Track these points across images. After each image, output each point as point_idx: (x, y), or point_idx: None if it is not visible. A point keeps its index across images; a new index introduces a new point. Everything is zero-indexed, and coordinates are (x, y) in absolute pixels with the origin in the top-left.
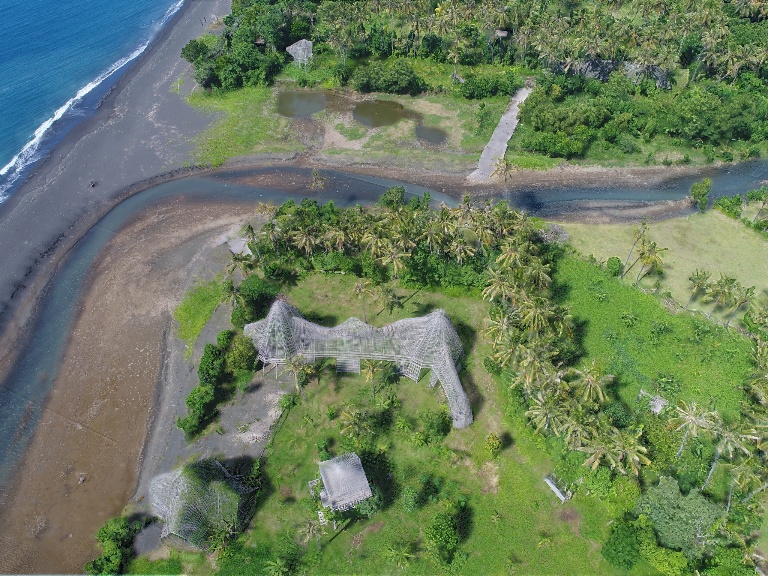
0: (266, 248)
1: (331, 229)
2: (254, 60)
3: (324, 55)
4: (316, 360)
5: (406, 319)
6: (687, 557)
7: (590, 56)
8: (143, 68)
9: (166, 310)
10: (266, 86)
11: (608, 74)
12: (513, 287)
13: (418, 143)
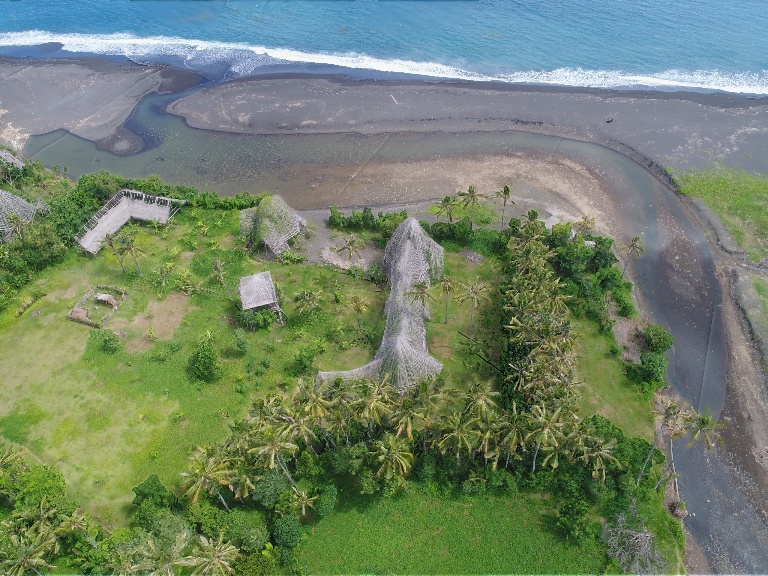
0: None
1: None
2: None
3: None
4: None
5: (406, 320)
6: None
7: None
8: None
9: None
10: None
11: None
12: None
13: None
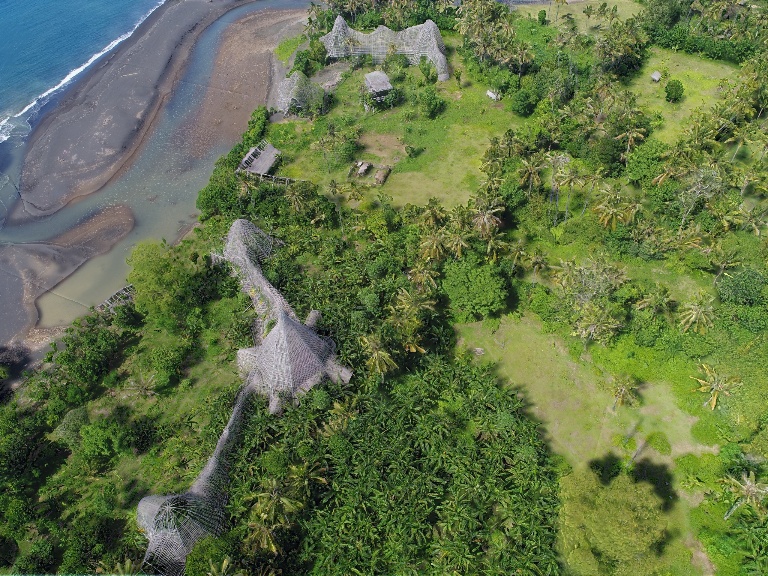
0: (327, 16)
1: None
2: None
3: None
4: (360, 61)
5: (412, 26)
6: None
7: None
8: None
9: (268, 51)
10: None
11: None
12: (472, 1)
13: None
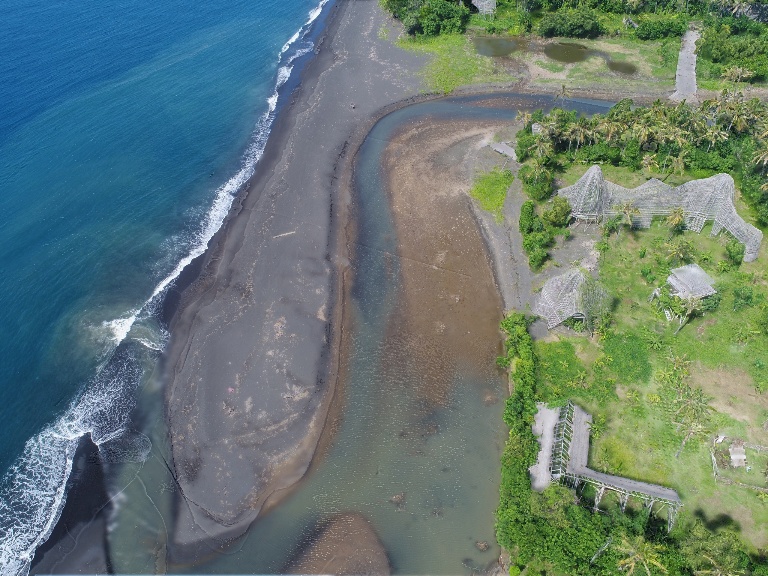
0: None
1: (601, 123)
2: (449, 11)
3: (499, 9)
4: None
5: (695, 180)
6: None
7: (749, 1)
8: (342, 22)
9: (462, 192)
10: (460, 33)
11: (767, 16)
12: None
13: (614, 74)
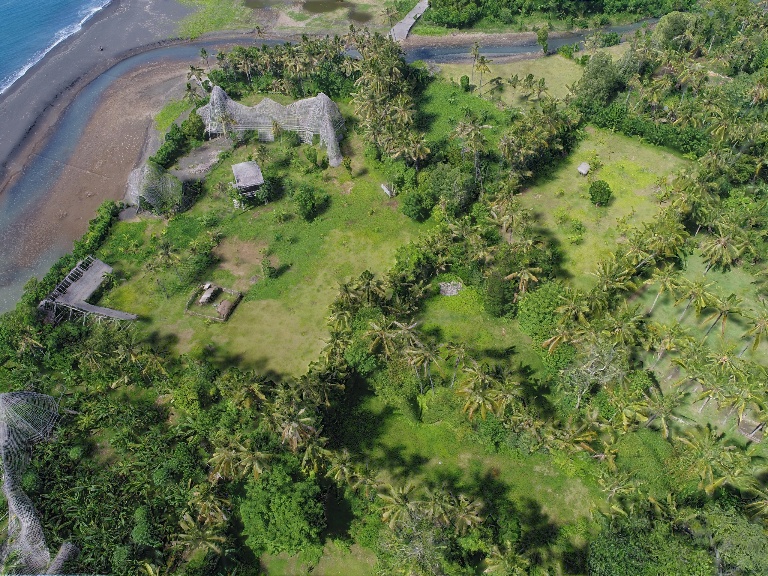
0: (220, 76)
1: None
2: None
3: None
4: (246, 136)
5: None
6: (448, 204)
7: None
8: None
9: (149, 116)
10: None
11: None
12: (370, 72)
13: (348, 22)
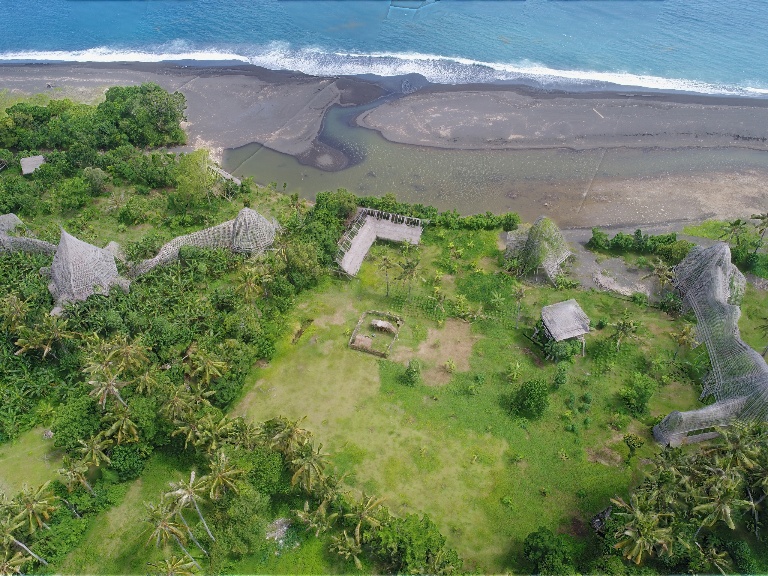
0: None
1: None
2: None
3: None
4: None
5: (760, 356)
6: None
7: None
8: None
9: (712, 215)
10: None
11: None
12: None
13: None
